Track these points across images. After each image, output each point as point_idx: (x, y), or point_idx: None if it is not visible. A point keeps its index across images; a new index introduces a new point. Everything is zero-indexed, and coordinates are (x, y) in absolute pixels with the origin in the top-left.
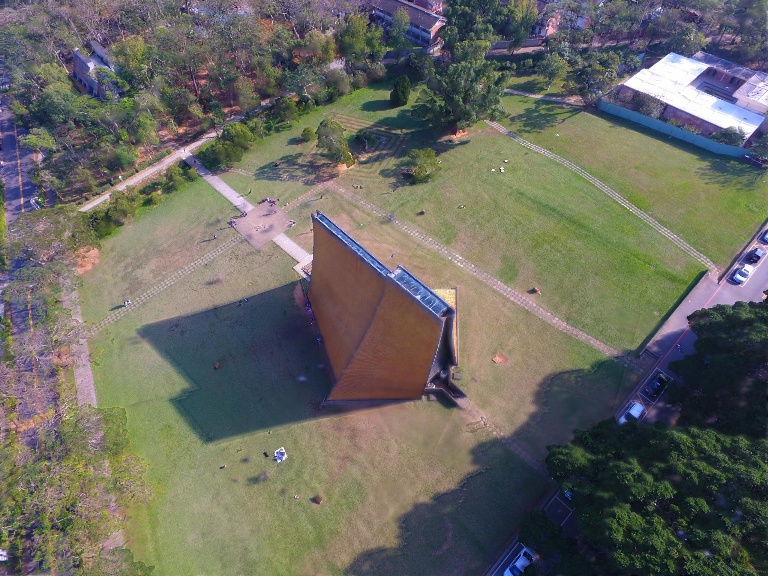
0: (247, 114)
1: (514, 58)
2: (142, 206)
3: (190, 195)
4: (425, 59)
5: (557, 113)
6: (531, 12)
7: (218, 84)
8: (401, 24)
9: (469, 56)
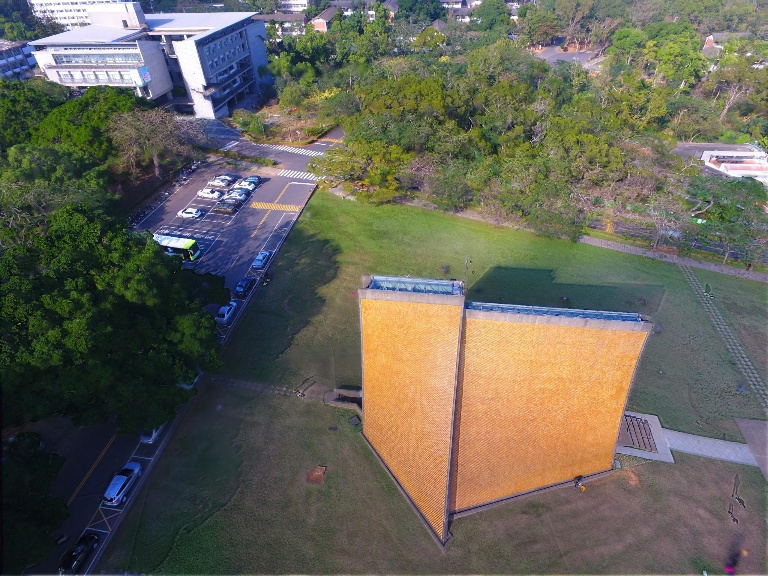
0: None
1: None
2: None
3: None
4: None
5: None
6: None
7: None
8: None
9: None
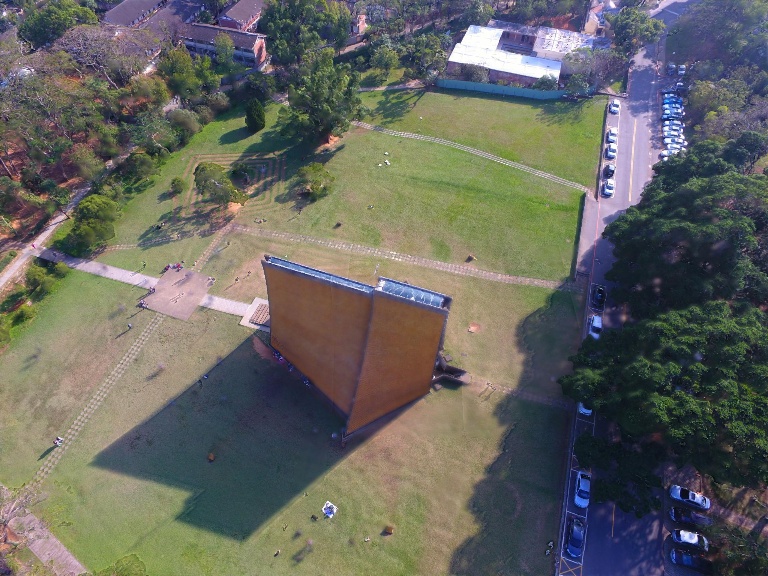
0: (94, 183)
1: (342, 58)
2: (12, 327)
3: (70, 293)
4: (265, 78)
5: (406, 99)
6: (344, 13)
7: (40, 160)
8: (226, 49)
9: (320, 65)
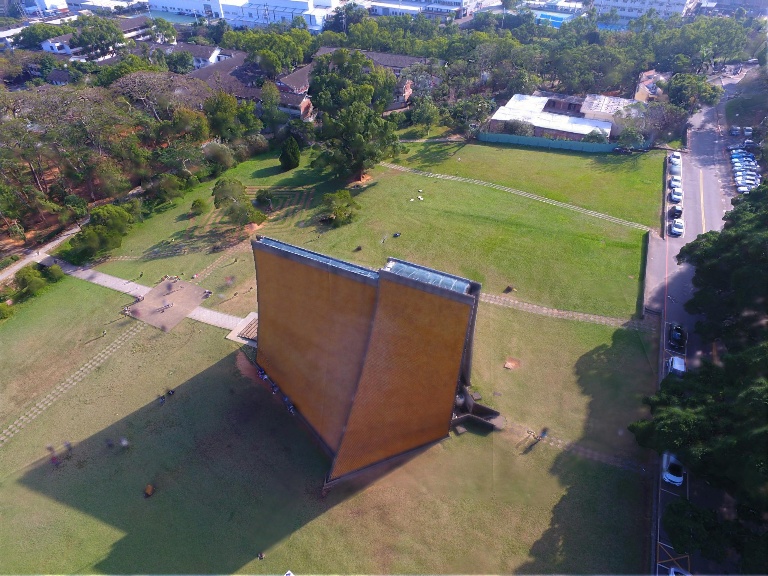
0: (116, 202)
1: (385, 119)
2: None
3: (56, 297)
4: (305, 124)
5: (446, 149)
6: (390, 77)
7: (72, 179)
8: (272, 97)
9: (357, 99)
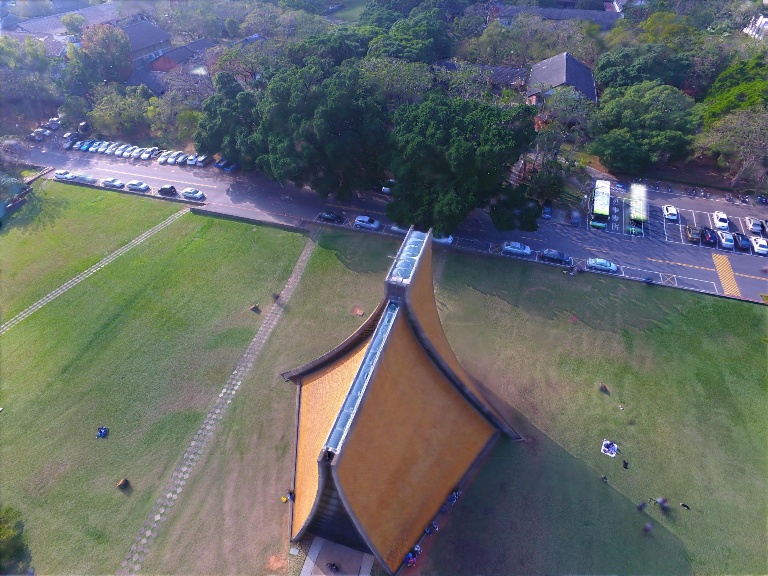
0: None
1: None
2: None
3: None
4: None
5: None
6: None
7: None
8: None
9: None
